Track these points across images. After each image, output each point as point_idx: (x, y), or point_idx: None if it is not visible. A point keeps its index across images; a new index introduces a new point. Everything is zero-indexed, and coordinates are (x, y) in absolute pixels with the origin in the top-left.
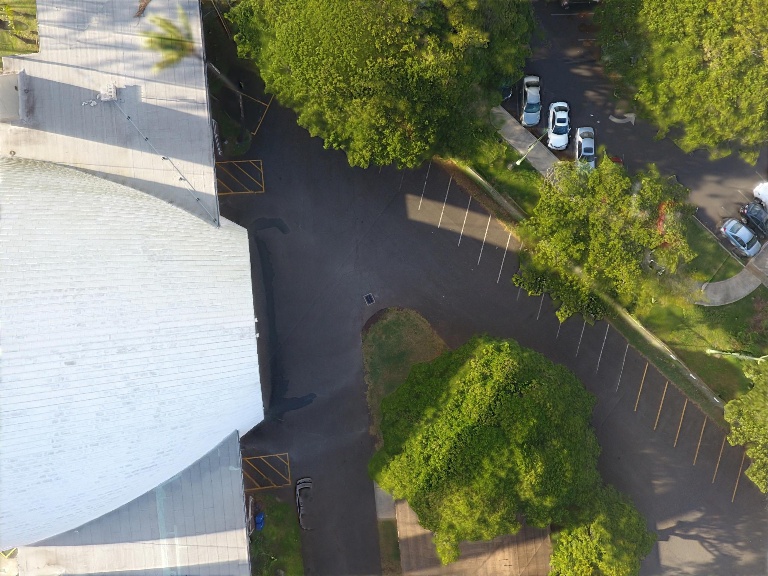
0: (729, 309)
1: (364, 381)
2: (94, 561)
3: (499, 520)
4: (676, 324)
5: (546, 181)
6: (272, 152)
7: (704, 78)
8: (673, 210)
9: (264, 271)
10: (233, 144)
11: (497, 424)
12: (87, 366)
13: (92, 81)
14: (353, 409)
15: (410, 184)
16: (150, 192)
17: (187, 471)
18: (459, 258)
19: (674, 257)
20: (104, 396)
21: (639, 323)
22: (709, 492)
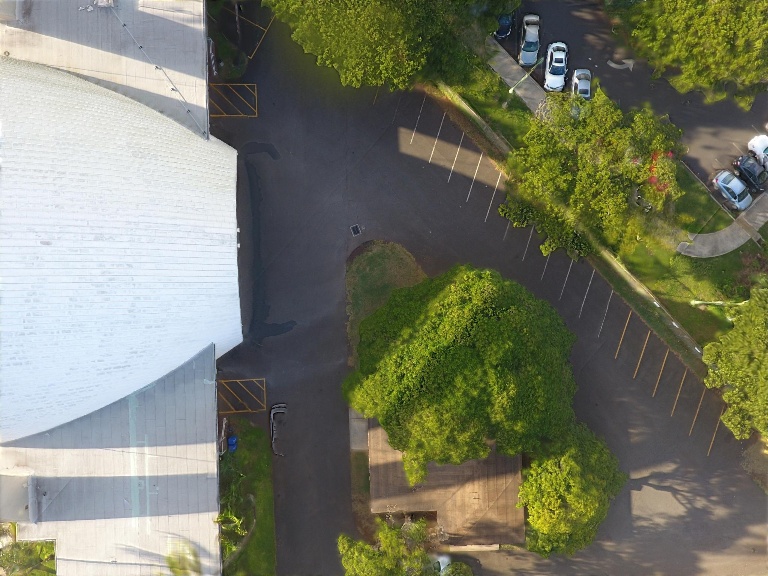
0: (716, 262)
1: (345, 312)
2: (63, 465)
3: (468, 440)
4: (662, 273)
5: (538, 112)
6: (267, 77)
7: (702, 12)
8: (663, 146)
9: (252, 195)
10: (229, 67)
11: (472, 345)
12: (63, 248)
13: None
14: (333, 339)
15: (403, 117)
16: (141, 101)
17: (161, 381)
18: (448, 194)
19: (661, 194)
20: (78, 281)
21: (624, 267)
22: (685, 444)
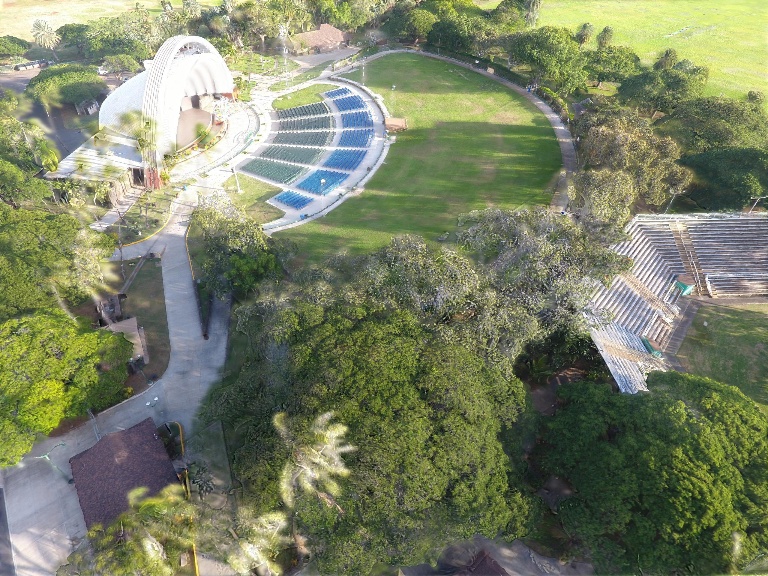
0: None
1: None
2: None
3: None
4: None
5: None
6: None
7: None
8: None
9: None
10: None
11: None
12: None
13: None
14: None
15: None
16: None
17: None
18: None
19: None
20: None
21: None
22: None
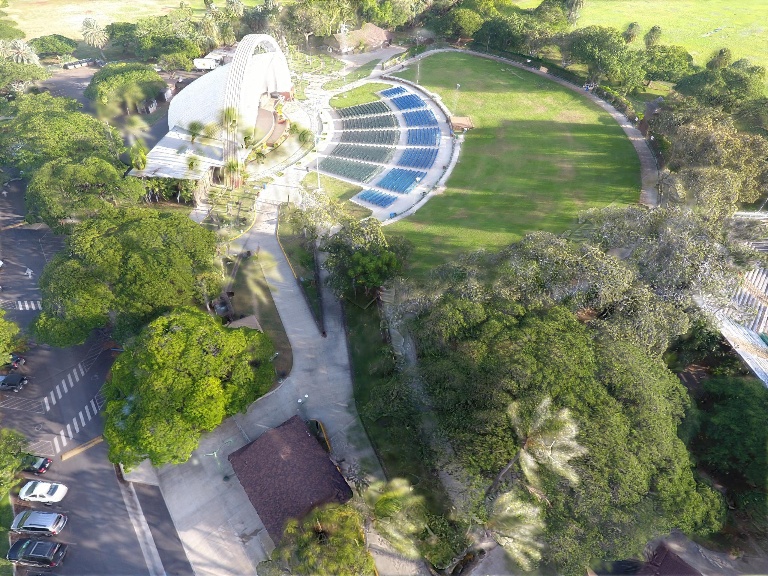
0: None
1: None
2: None
3: None
4: None
5: None
6: None
7: None
8: None
9: None
10: None
11: None
12: None
13: (194, 156)
14: None
15: None
16: (193, 133)
17: None
18: None
19: None
20: None
21: None
22: None
